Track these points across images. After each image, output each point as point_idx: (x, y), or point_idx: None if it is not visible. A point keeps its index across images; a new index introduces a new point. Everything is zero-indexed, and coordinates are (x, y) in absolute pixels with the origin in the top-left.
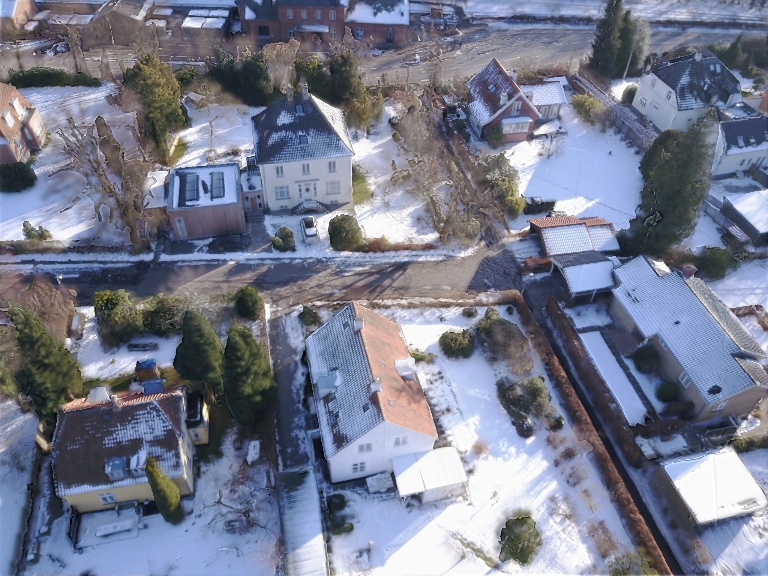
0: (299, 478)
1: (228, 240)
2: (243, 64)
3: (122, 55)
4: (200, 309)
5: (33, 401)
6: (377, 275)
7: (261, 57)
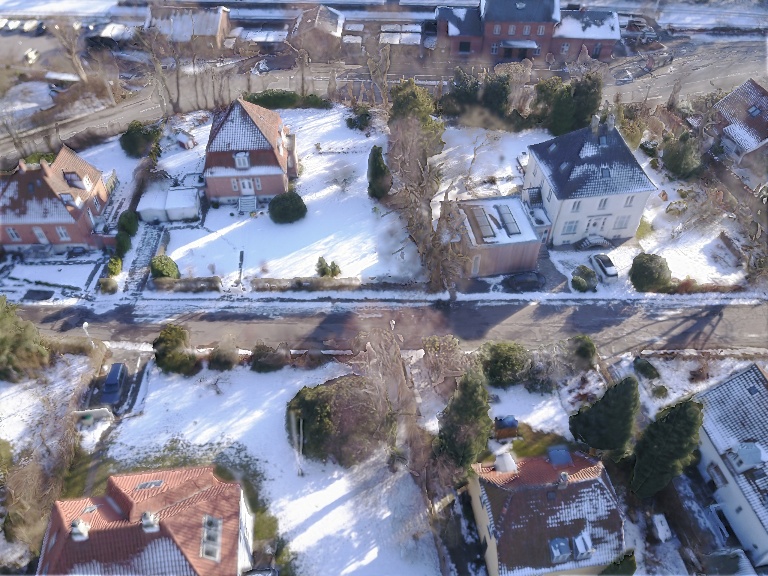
0: (733, 563)
1: (526, 279)
2: (488, 86)
3: (326, 73)
4: (555, 362)
5: (448, 469)
6: (694, 320)
7: (507, 79)
